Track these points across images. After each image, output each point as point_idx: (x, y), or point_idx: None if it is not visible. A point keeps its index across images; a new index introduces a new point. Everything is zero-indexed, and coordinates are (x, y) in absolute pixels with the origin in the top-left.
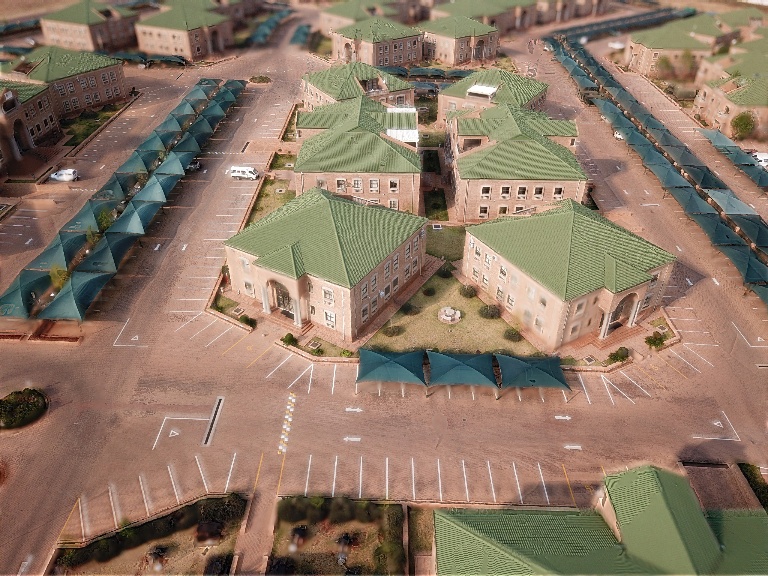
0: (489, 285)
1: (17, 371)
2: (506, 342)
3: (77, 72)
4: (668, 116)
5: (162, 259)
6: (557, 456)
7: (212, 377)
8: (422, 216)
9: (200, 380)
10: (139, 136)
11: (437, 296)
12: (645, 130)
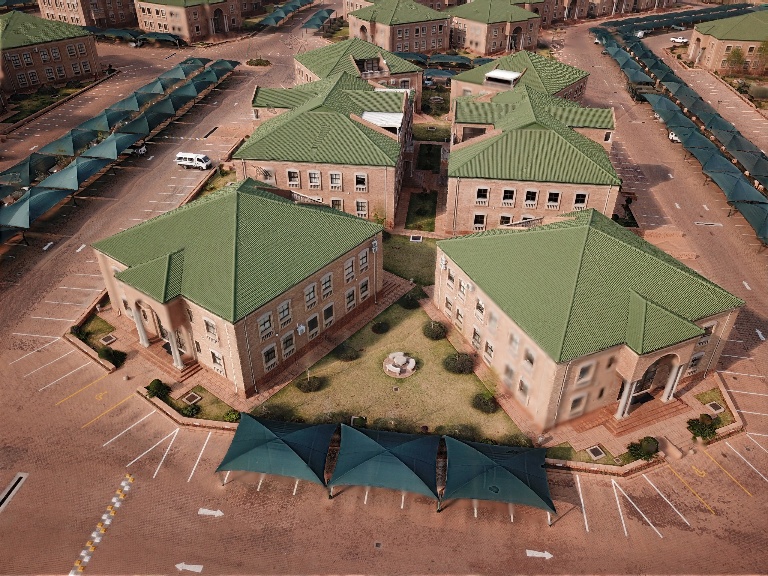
0: (464, 324)
1: None
2: (473, 413)
3: (36, 41)
4: (740, 118)
5: (45, 262)
6: None
7: (25, 439)
8: (400, 224)
9: (6, 443)
10: (94, 116)
11: (390, 335)
12: (709, 131)
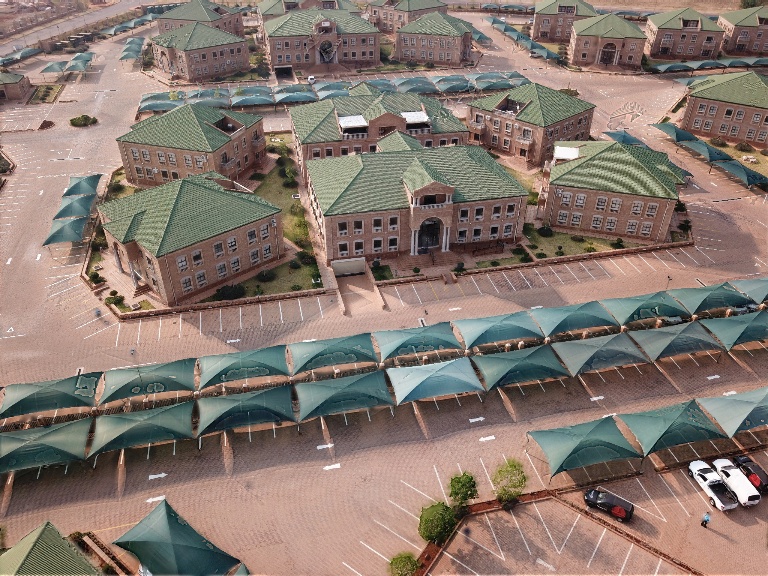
0: None
1: (114, 116)
2: None
3: (422, 32)
4: None
5: None
6: (4, 254)
7: None
8: None
9: None
10: None
11: None
12: None
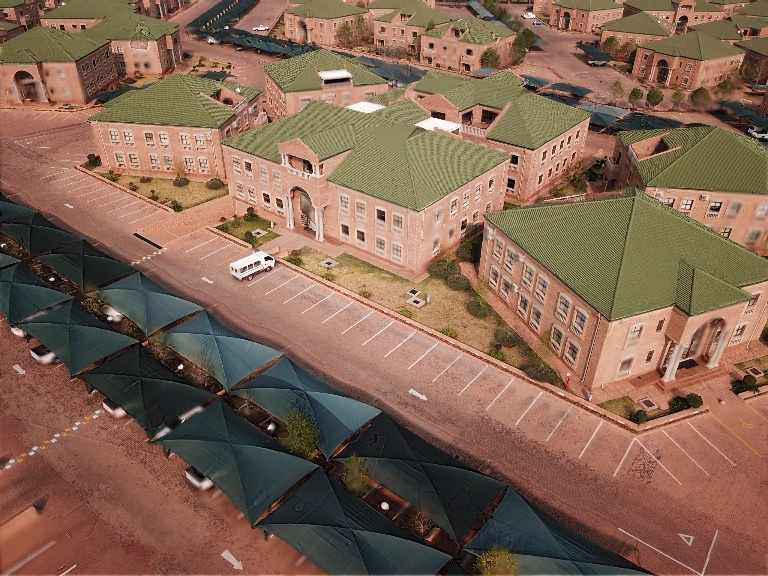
0: None
1: None
2: None
3: None
4: None
5: (438, 430)
6: None
7: None
8: None
9: None
10: None
11: None
12: None
